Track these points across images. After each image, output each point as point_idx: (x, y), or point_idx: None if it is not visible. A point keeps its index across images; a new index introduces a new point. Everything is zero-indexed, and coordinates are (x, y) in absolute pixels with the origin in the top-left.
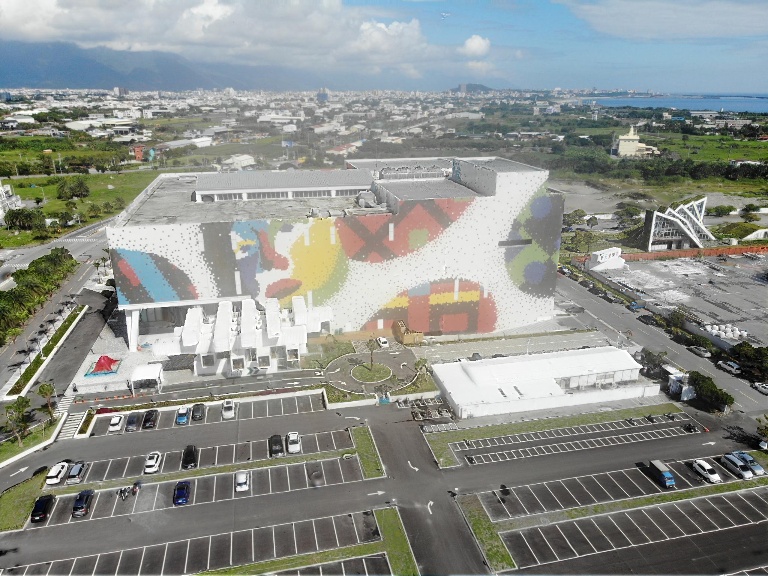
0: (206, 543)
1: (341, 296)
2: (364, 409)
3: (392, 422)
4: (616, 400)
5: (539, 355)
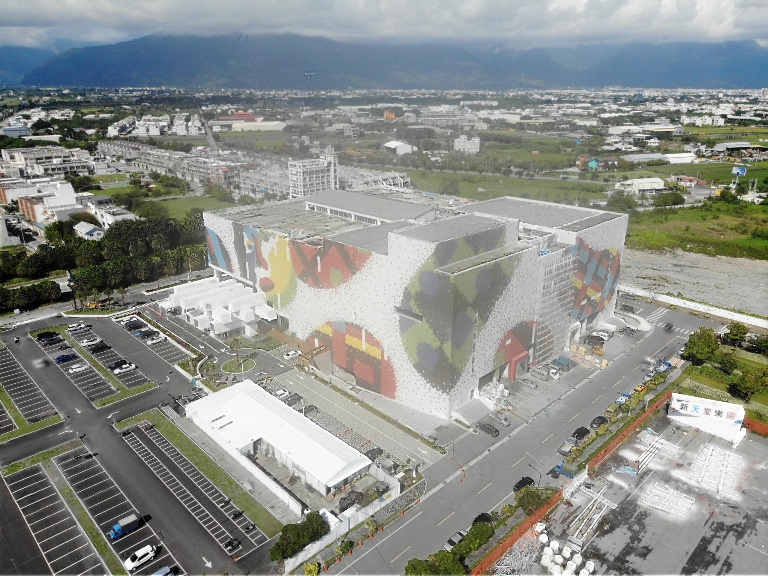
0: (25, 379)
1: (294, 306)
2: (182, 378)
3: (168, 393)
4: (270, 489)
5: (303, 419)
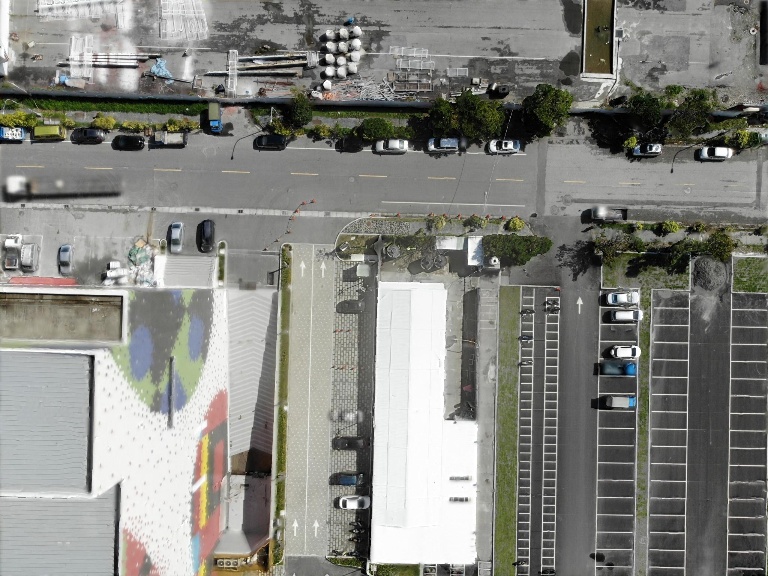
0: None
1: None
2: None
3: None
4: None
5: (385, 410)
